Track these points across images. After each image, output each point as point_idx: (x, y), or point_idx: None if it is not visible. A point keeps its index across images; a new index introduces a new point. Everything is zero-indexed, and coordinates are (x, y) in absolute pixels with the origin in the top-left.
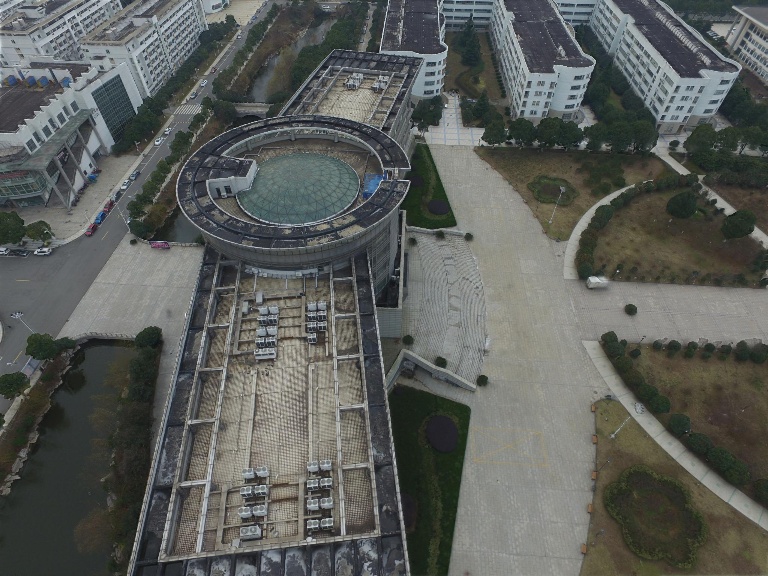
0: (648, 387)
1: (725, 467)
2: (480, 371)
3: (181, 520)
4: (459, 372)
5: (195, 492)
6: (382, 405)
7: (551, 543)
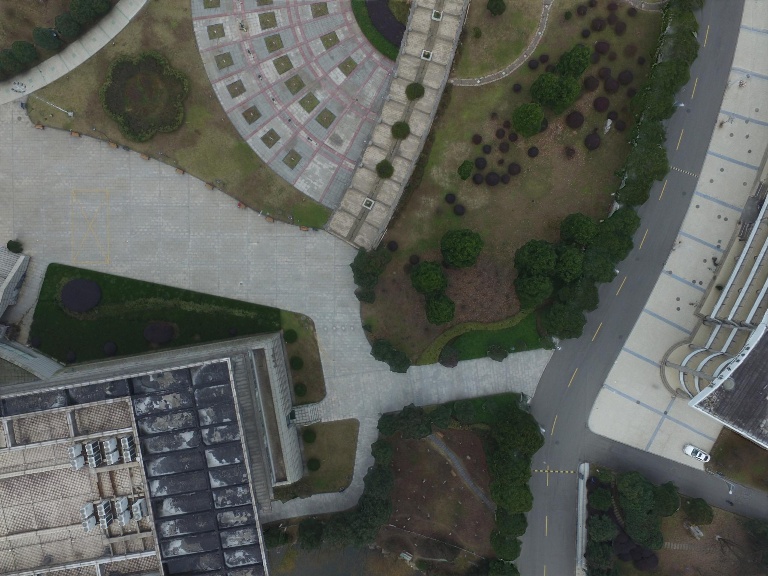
0: (2, 60)
1: (90, 11)
2: (3, 248)
3: (138, 571)
4: (4, 274)
5: (113, 567)
6: (3, 401)
7: (178, 200)
